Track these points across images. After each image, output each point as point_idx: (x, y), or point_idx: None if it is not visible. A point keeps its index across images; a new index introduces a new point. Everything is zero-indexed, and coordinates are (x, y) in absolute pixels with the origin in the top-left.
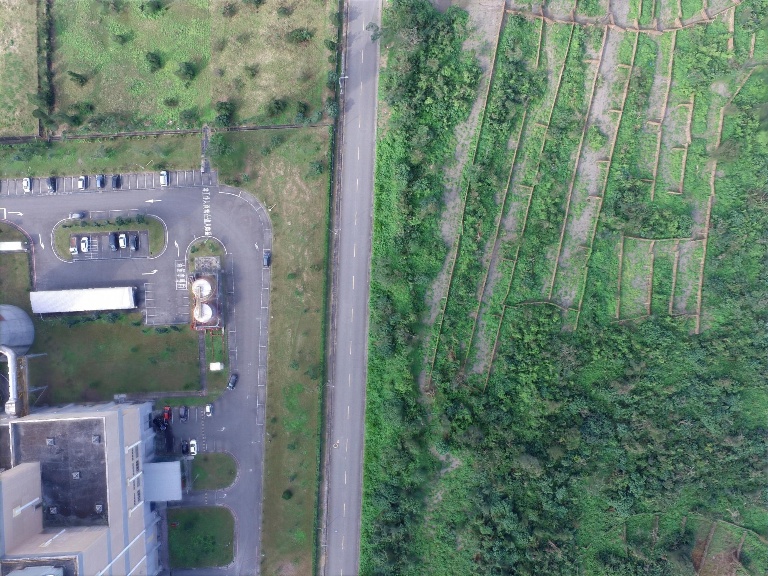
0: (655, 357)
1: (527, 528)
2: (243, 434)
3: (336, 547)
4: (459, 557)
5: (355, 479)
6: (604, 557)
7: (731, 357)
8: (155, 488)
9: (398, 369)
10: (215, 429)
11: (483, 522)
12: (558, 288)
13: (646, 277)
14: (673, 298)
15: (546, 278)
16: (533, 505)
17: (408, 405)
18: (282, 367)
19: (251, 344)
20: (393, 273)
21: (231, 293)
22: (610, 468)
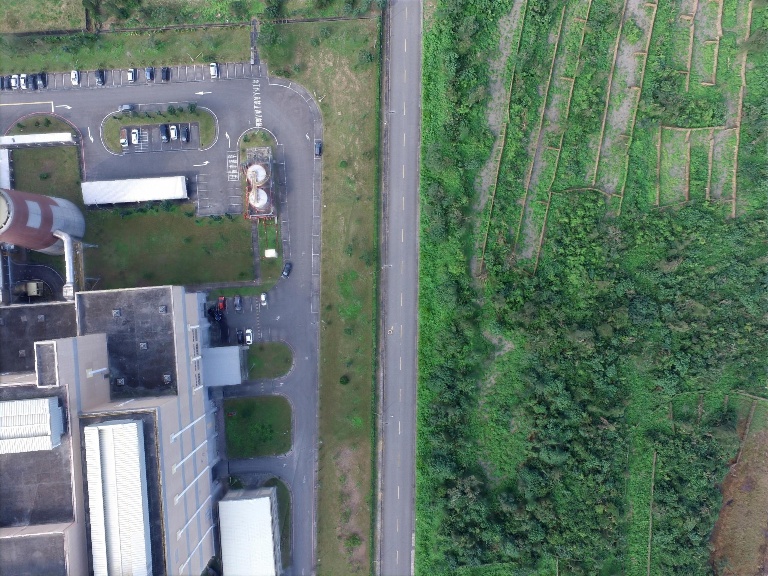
0: (696, 239)
1: (580, 405)
2: (298, 322)
3: (393, 432)
4: (513, 439)
5: (410, 365)
6: (653, 434)
7: (767, 238)
8: (214, 373)
9: (451, 252)
10: (270, 318)
11: (537, 402)
12: (601, 175)
13: (683, 166)
14: (710, 185)
15: (589, 166)
16: (584, 384)
17: (461, 288)
18: (336, 255)
19: (304, 233)
20: (443, 160)
21: (283, 183)
22: (655, 349)
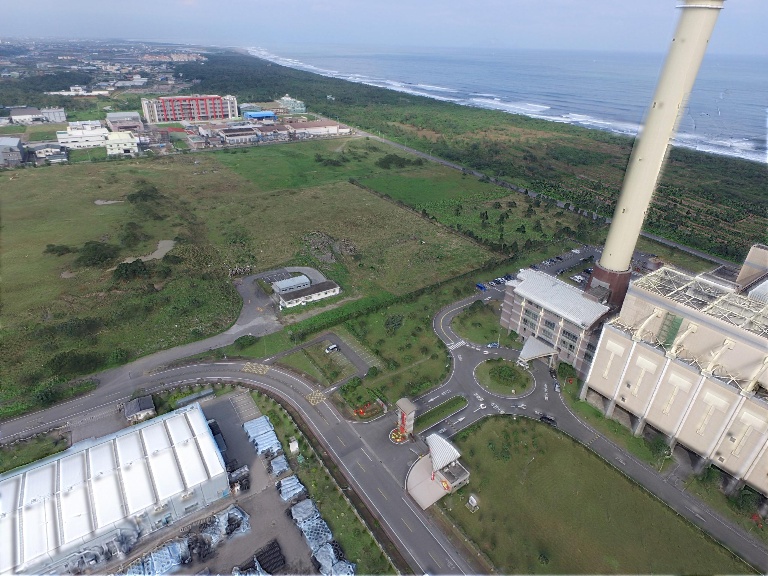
0: None
1: None
2: None
3: None
4: None
5: None
6: None
7: None
8: None
9: None
10: None
11: None
12: None
13: (761, 228)
14: None
15: None
16: None
17: None
18: None
19: None
20: None
21: None
22: None
